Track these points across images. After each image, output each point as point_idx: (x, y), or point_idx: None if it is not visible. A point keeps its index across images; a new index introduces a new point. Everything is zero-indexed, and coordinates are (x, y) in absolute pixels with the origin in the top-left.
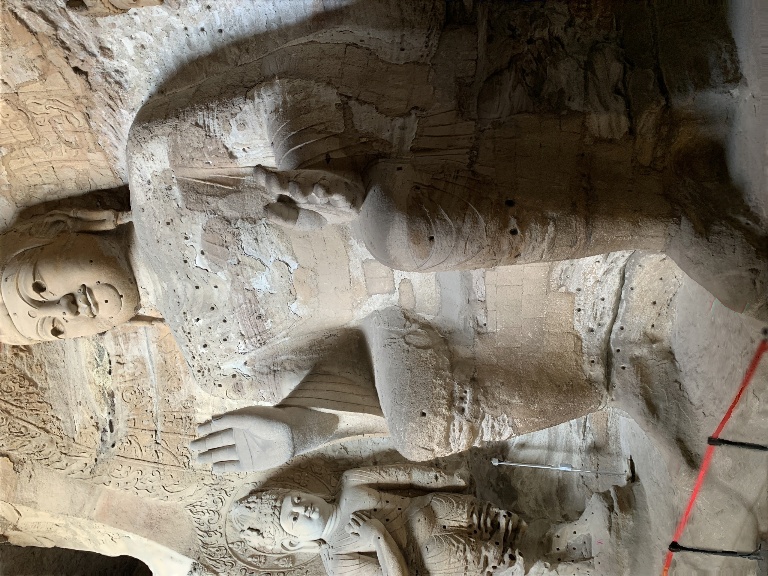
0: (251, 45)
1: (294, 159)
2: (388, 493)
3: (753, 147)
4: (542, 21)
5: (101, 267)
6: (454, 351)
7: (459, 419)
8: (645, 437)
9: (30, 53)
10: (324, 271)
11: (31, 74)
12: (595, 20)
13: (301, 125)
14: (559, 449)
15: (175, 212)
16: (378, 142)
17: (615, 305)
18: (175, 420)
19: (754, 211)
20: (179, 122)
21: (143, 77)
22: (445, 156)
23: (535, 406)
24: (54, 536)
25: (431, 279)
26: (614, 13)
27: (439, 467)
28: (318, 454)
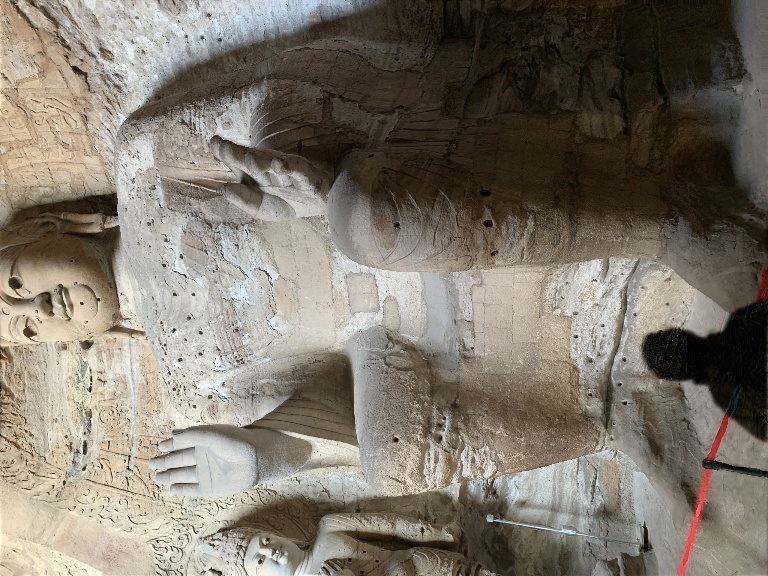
0: (249, 54)
1: (266, 147)
2: (367, 543)
3: (758, 142)
4: (538, 29)
5: (80, 268)
6: (436, 375)
7: (435, 448)
8: (658, 497)
9: (31, 49)
10: (306, 284)
11: (31, 70)
12: (595, 31)
13: (278, 116)
14: (564, 510)
15: (156, 212)
16: (354, 132)
17: (617, 333)
18: (150, 446)
19: (759, 207)
20: (166, 119)
21: (142, 82)
22: (421, 147)
23: (522, 439)
24: (11, 564)
25: (417, 297)
26: (615, 25)
27: (428, 520)
28: (297, 495)
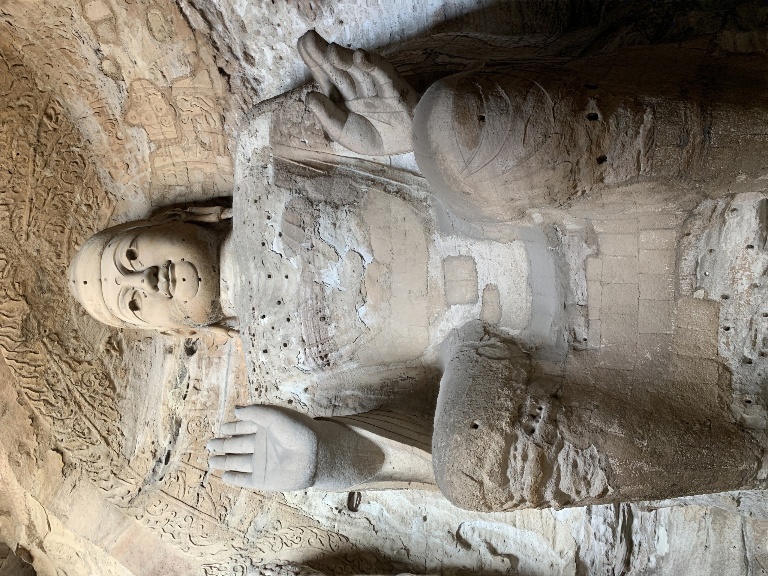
0: None
1: None
2: None
3: None
4: None
5: (190, 246)
6: (537, 366)
7: (524, 440)
8: None
9: (187, 48)
10: (400, 268)
11: (185, 69)
12: None
13: None
14: None
15: (264, 189)
16: (452, 64)
17: None
18: None
19: None
20: (285, 99)
21: (275, 85)
22: None
23: (644, 443)
24: (72, 571)
25: (522, 283)
26: None
27: None
28: (372, 547)
